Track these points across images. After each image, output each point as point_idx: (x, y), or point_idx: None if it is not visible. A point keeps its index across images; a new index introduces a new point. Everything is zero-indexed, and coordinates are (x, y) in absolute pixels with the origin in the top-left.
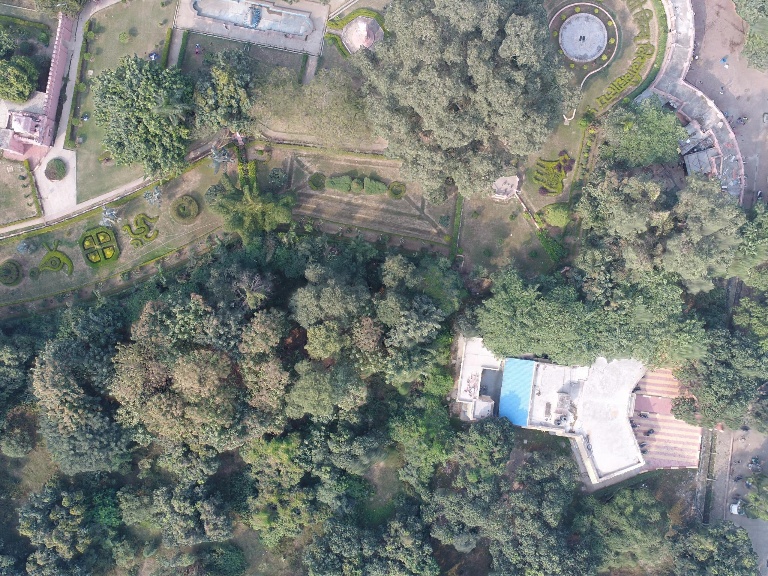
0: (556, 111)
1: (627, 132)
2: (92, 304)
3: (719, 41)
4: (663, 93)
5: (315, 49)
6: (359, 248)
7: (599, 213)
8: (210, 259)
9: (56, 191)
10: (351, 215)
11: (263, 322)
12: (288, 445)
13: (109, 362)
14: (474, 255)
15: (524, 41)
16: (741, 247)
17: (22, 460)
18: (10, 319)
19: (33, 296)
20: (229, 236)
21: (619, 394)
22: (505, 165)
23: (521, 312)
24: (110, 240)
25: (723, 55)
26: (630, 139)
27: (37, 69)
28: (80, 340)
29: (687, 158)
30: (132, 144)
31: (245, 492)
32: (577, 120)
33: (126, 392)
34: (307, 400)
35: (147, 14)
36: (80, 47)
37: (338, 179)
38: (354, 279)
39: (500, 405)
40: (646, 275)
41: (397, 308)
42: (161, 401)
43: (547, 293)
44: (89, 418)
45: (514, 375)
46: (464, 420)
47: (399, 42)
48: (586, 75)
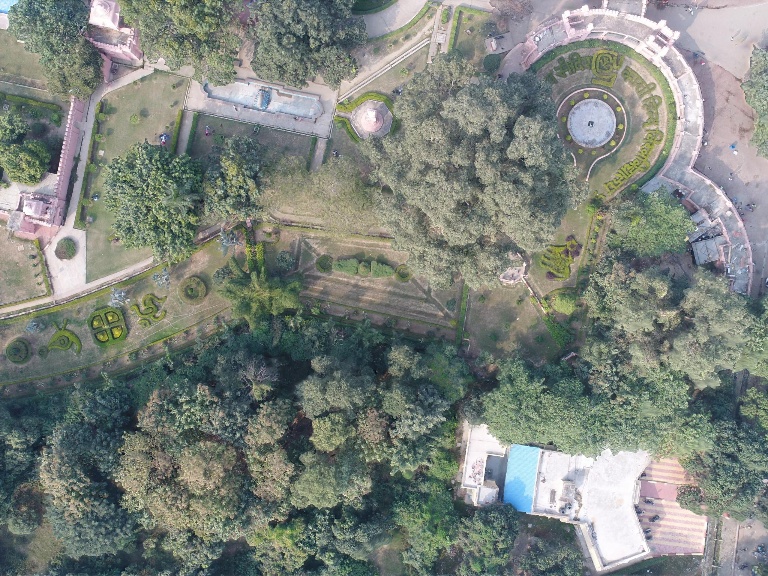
0: (564, 206)
1: (635, 225)
2: (100, 385)
3: (728, 127)
4: (671, 181)
5: (324, 132)
6: (365, 334)
7: (606, 304)
8: (217, 342)
9: (66, 270)
10: (358, 297)
11: (269, 415)
12: (292, 531)
13: (116, 447)
14: (480, 339)
15: (532, 143)
16: (748, 343)
17: (28, 536)
18: (18, 397)
19: (41, 374)
20: (236, 320)
21: (624, 482)
22: (512, 255)
23: (526, 405)
24: (118, 320)
25: (732, 141)
26: (638, 232)
27: (49, 151)
28: (87, 425)
29: (695, 245)
30: (141, 231)
31: (249, 573)
32: (585, 205)
33: (132, 485)
34: (312, 493)
35: (158, 95)
36: (91, 128)
37: (345, 262)
38: (360, 366)
39: (505, 491)
40: (652, 371)
41: (402, 401)
42: (166, 494)
43: (553, 385)
44: (95, 505)
45: (519, 461)
46: (468, 503)
47: (407, 141)
48: (594, 160)
